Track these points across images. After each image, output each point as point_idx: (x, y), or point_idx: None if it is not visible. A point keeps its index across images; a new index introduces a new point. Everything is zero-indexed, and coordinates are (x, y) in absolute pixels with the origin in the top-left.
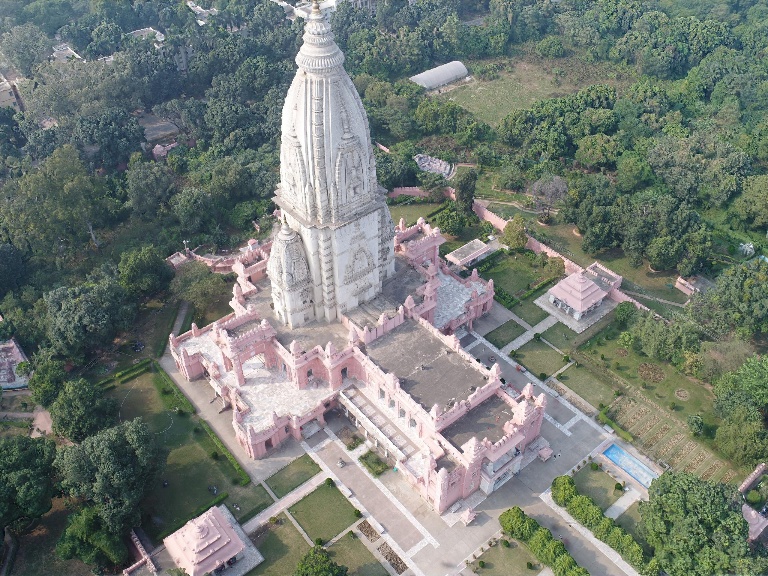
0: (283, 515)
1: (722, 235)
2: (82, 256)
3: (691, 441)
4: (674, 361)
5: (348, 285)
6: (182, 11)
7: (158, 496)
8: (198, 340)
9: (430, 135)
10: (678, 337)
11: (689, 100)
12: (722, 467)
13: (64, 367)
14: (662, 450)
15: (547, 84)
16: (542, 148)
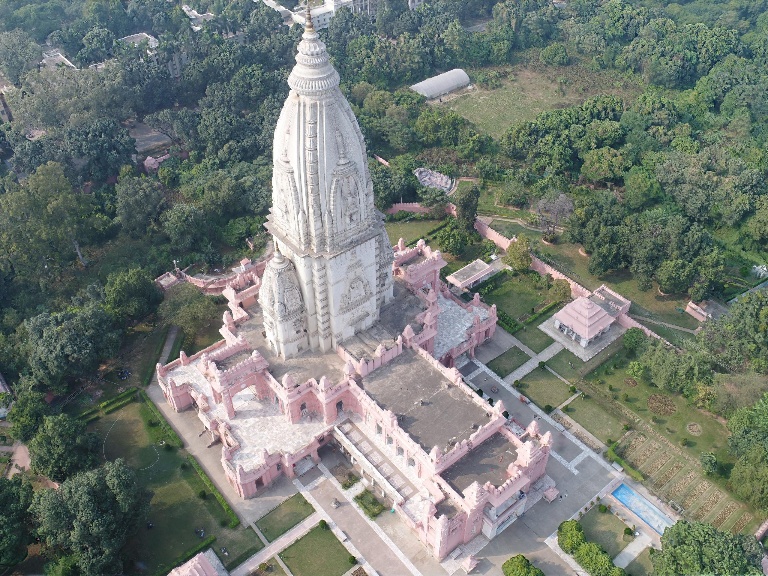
0: (274, 561)
1: (734, 256)
2: (68, 275)
3: (704, 480)
4: (685, 393)
5: (344, 315)
6: (177, 16)
7: (142, 539)
8: (187, 369)
9: (431, 147)
10: (690, 368)
11: (698, 111)
12: (737, 509)
13: (46, 397)
14: (674, 490)
15: (551, 93)
16: (547, 162)
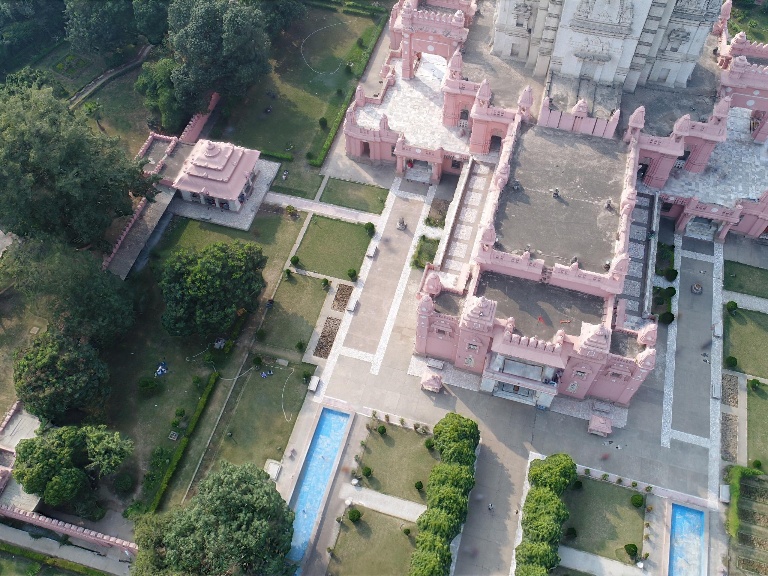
0: (305, 215)
1: None
2: None
3: None
4: None
5: (574, 32)
6: None
7: (253, 114)
8: None
9: None
10: None
11: None
12: None
13: None
14: None
15: None
16: None
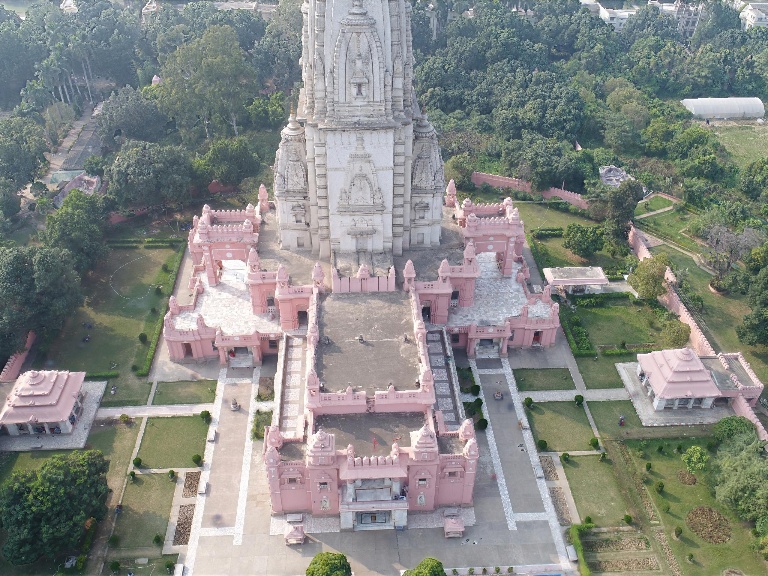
0: (139, 420)
1: None
2: None
3: None
4: (757, 528)
5: (342, 216)
6: None
7: (71, 345)
8: None
9: (652, 157)
10: None
11: None
12: None
13: None
14: None
15: None
16: None
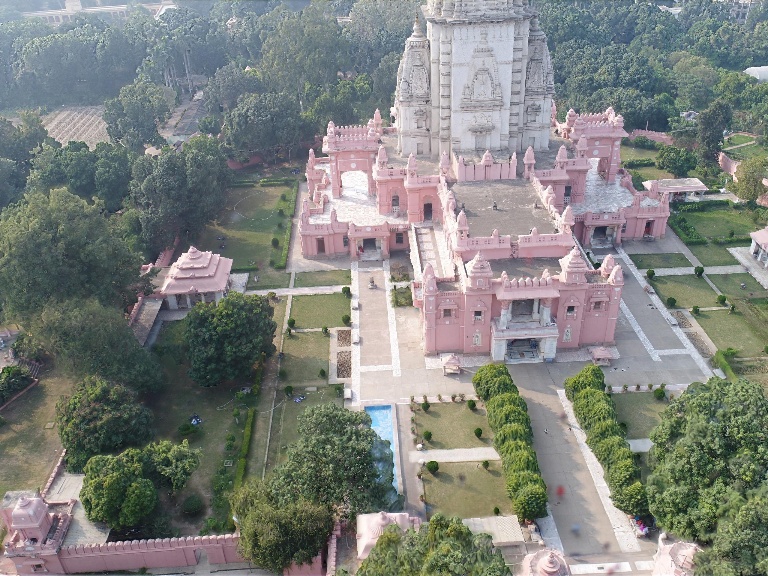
0: (285, 297)
1: None
2: None
3: None
4: None
5: (464, 113)
6: None
7: None
8: None
9: None
10: None
11: None
12: None
13: None
14: None
15: None
16: None
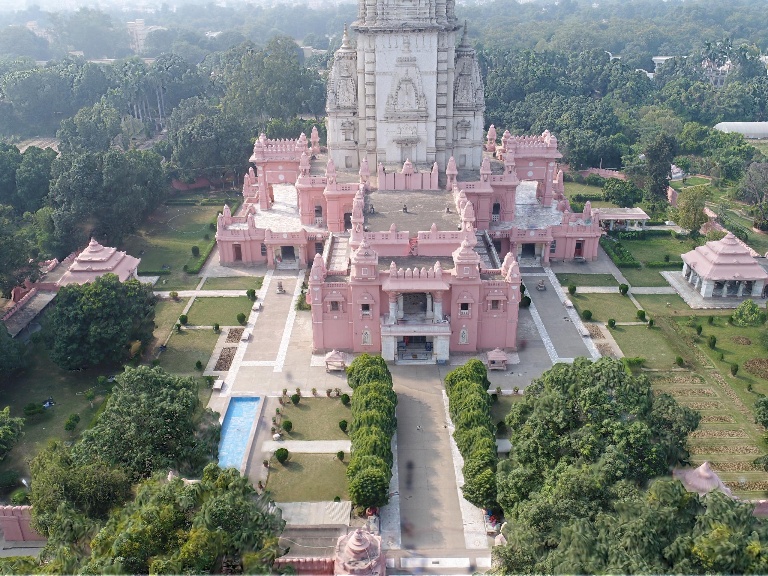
0: (188, 298)
1: None
2: None
3: (753, 445)
4: None
5: (389, 124)
6: None
7: None
8: (273, 185)
9: None
10: None
11: None
12: None
13: None
14: None
15: None
16: None
